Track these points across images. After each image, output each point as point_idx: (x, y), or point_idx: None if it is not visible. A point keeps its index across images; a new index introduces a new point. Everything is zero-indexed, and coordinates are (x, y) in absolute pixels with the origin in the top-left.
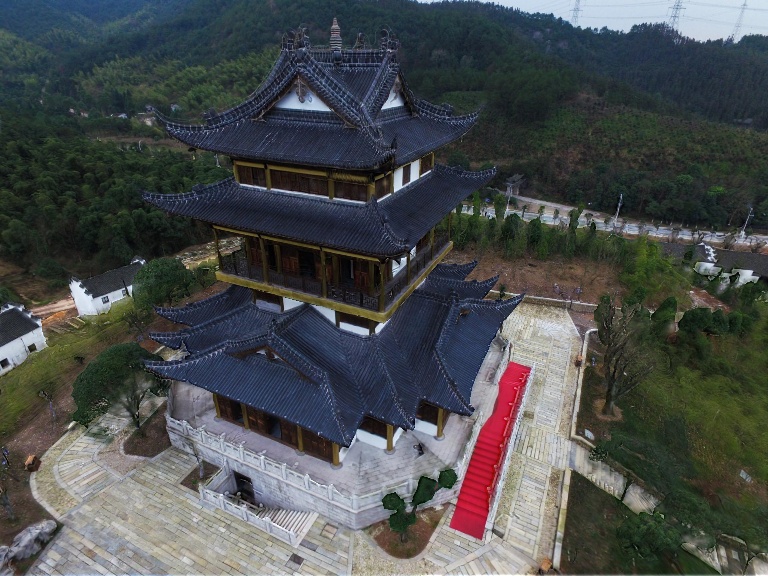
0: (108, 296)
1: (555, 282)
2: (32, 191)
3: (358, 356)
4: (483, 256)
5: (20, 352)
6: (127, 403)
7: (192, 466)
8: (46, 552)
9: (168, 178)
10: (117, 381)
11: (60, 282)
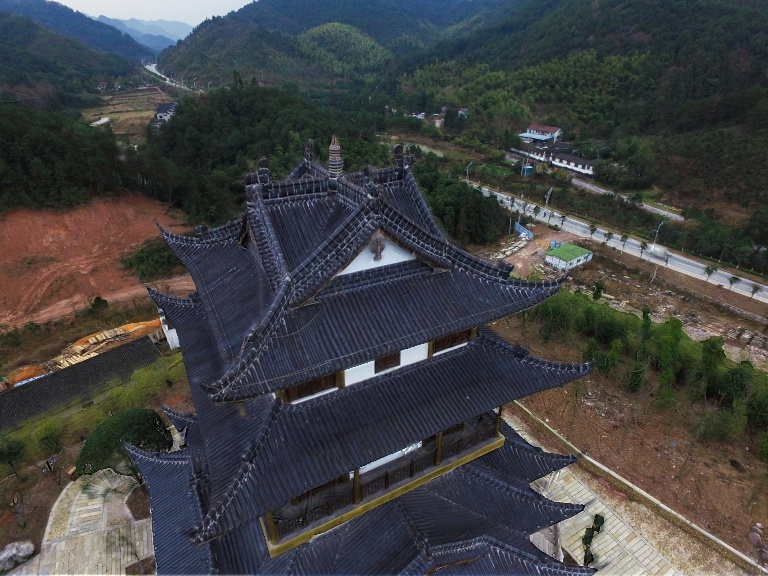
0: None
1: (760, 520)
2: None
3: (277, 556)
4: (659, 415)
5: None
6: (130, 463)
7: (148, 553)
8: (12, 573)
9: None
10: (104, 451)
11: None
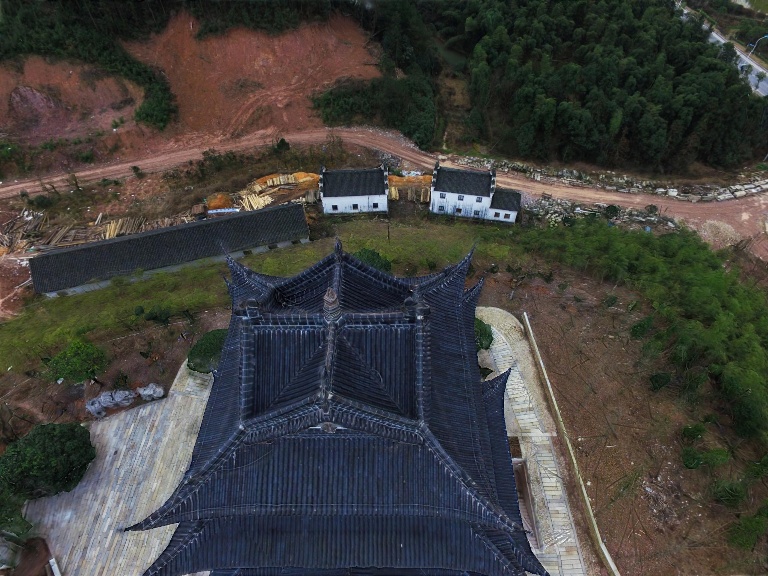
0: (446, 194)
1: None
2: (524, 32)
3: None
4: (726, 544)
5: (366, 205)
6: None
7: None
8: (149, 404)
9: (650, 65)
10: (200, 362)
11: (471, 138)
